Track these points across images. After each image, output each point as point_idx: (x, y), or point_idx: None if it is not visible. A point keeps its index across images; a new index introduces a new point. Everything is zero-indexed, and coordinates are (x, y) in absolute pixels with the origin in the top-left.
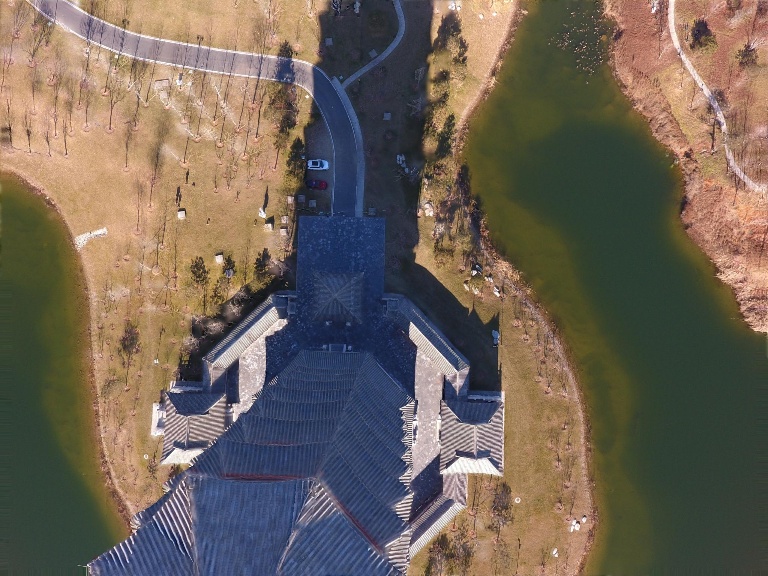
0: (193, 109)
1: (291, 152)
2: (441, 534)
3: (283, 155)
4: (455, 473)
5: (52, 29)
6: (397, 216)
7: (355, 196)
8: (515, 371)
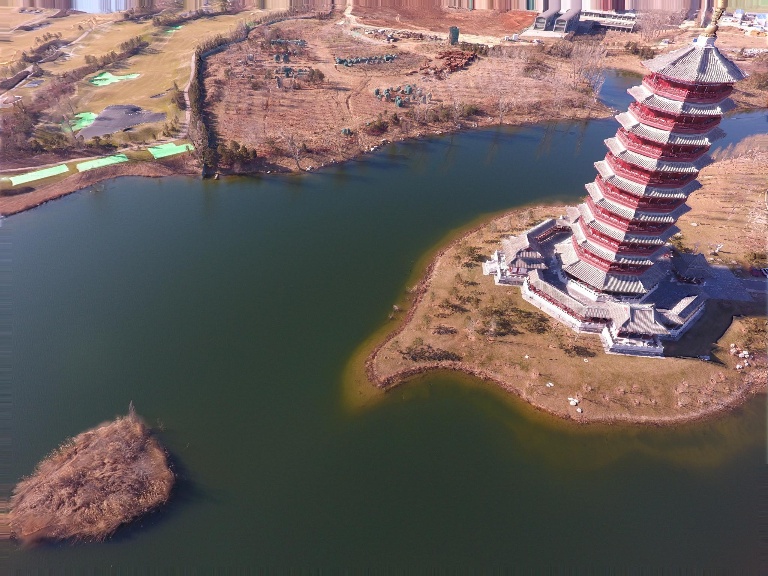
0: (760, 230)
1: (766, 264)
2: (548, 318)
3: (761, 260)
4: (607, 309)
5: (761, 193)
6: (761, 308)
7: (759, 289)
8: (685, 367)
